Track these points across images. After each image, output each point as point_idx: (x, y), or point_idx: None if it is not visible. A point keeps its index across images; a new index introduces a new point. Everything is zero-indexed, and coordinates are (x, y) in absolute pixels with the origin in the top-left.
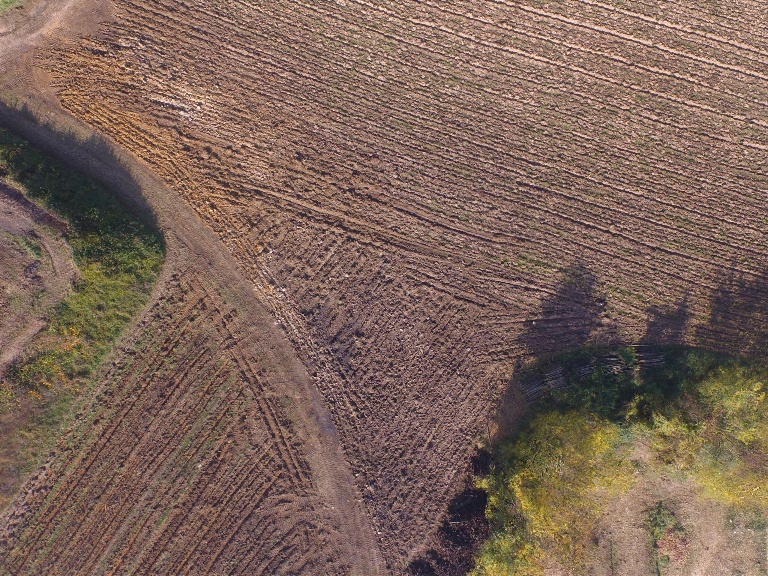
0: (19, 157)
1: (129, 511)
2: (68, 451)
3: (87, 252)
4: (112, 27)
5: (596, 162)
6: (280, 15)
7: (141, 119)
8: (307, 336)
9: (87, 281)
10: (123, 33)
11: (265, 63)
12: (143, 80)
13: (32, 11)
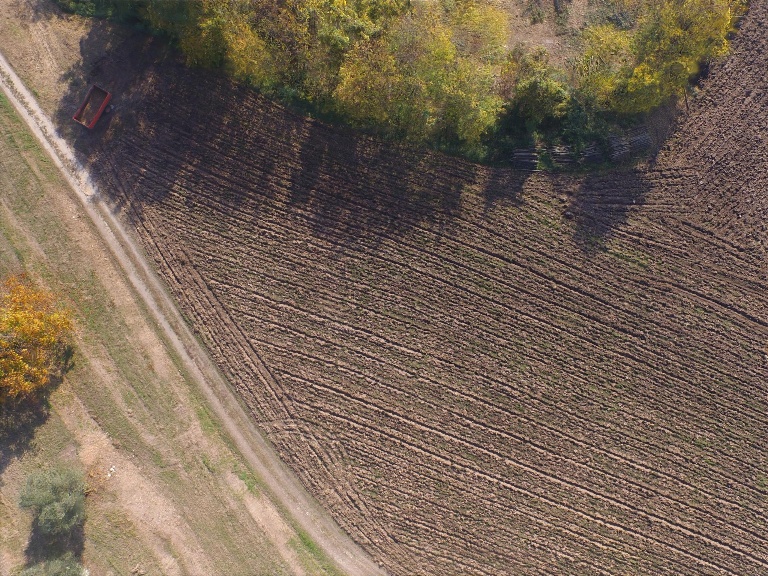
0: None
1: None
2: None
3: None
4: None
5: (566, 351)
6: None
7: None
8: None
9: None
10: None
11: None
12: None
13: None
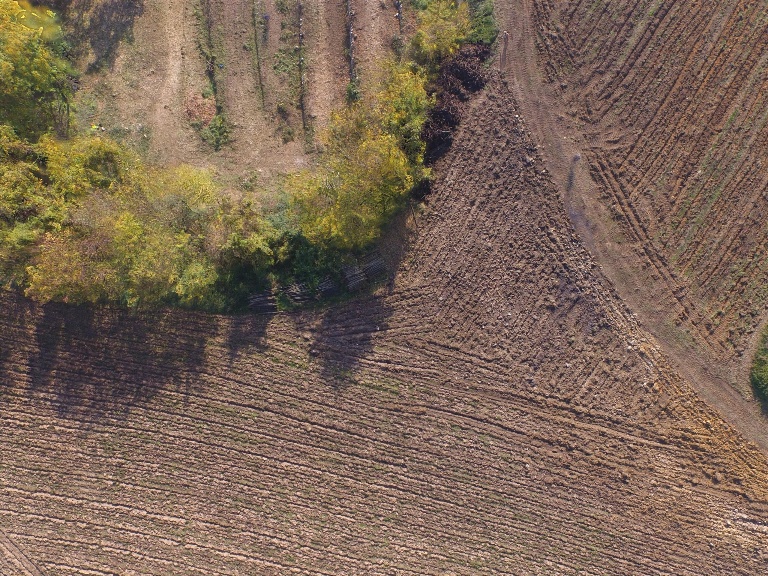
0: None
1: (765, 124)
2: None
3: None
4: None
5: (330, 492)
6: None
7: None
8: (604, 304)
9: None
10: None
11: (666, 571)
12: None
13: None
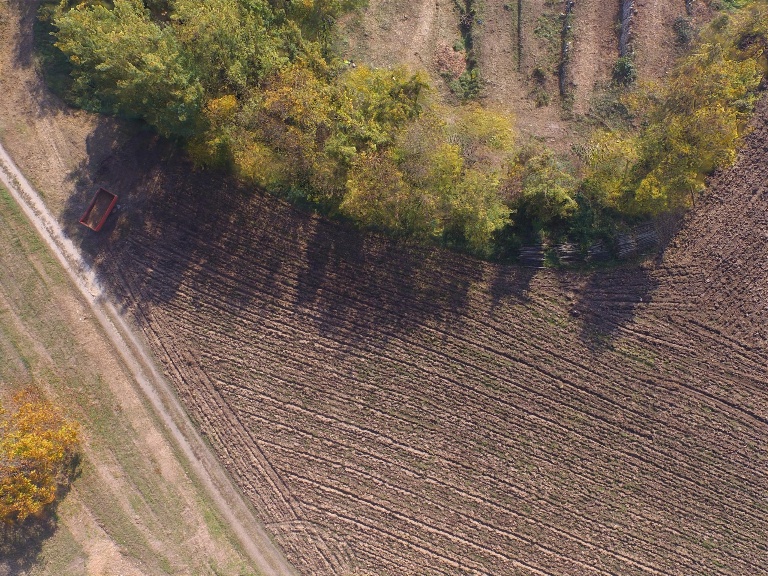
0: None
1: None
2: None
3: None
4: None
5: (573, 451)
6: None
7: None
8: None
9: None
10: None
11: None
12: None
13: None
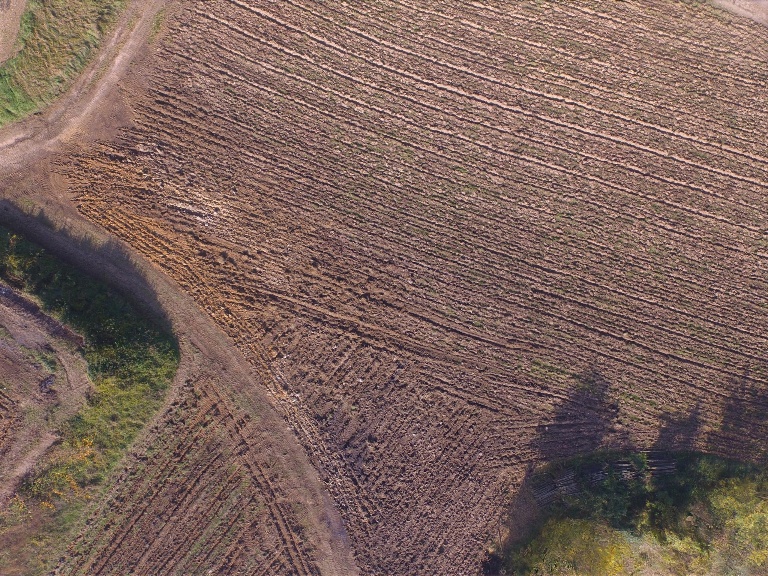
0: (35, 266)
1: None
2: (78, 556)
3: (102, 366)
4: (130, 132)
5: (611, 270)
6: (298, 121)
7: (158, 224)
8: (320, 441)
9: (102, 394)
10: (141, 138)
11: (282, 169)
12: (160, 186)
13: (50, 116)
